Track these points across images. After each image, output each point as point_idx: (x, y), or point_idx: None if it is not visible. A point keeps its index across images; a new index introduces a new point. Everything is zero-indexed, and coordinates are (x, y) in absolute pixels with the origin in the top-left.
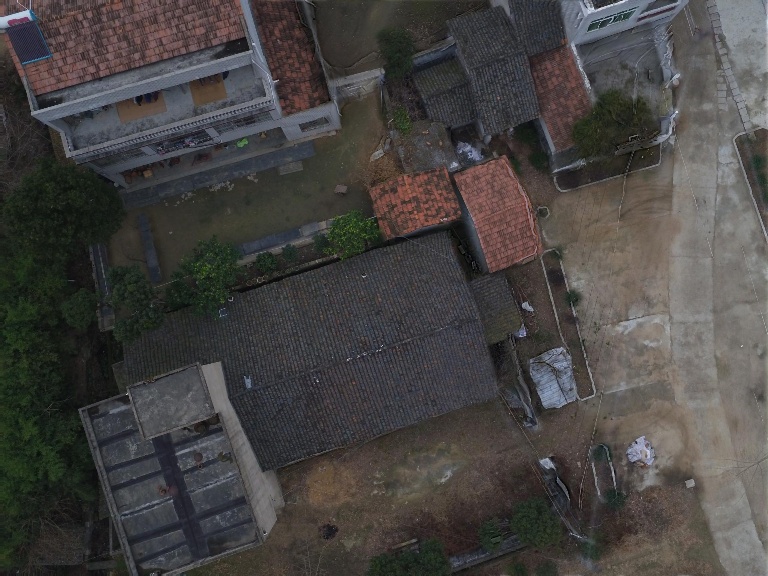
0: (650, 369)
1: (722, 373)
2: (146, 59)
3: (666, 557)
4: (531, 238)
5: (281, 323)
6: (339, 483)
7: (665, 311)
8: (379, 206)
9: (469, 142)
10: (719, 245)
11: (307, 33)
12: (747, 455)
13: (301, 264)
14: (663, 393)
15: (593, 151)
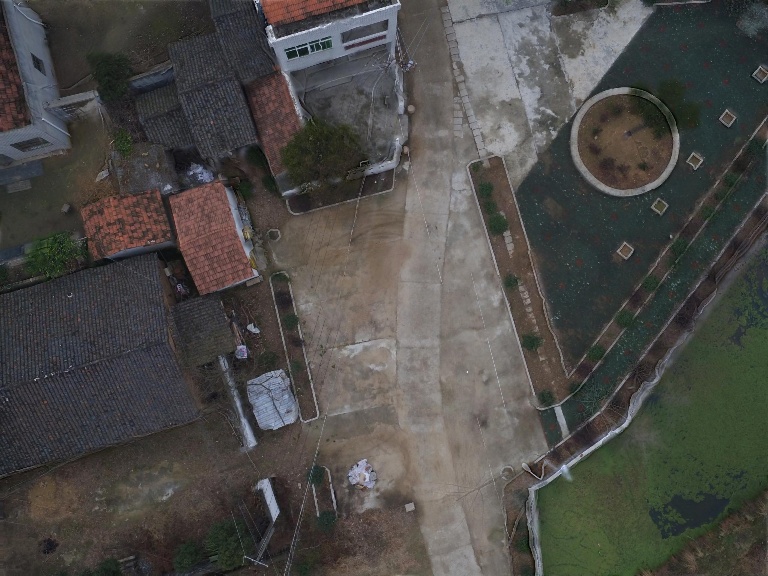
0: (375, 393)
1: (446, 398)
2: None
3: None
4: (240, 262)
5: None
6: (61, 498)
7: (392, 336)
8: (89, 227)
9: (200, 164)
10: (449, 271)
11: (10, 55)
12: (468, 480)
13: (14, 282)
14: (387, 417)
15: (319, 176)
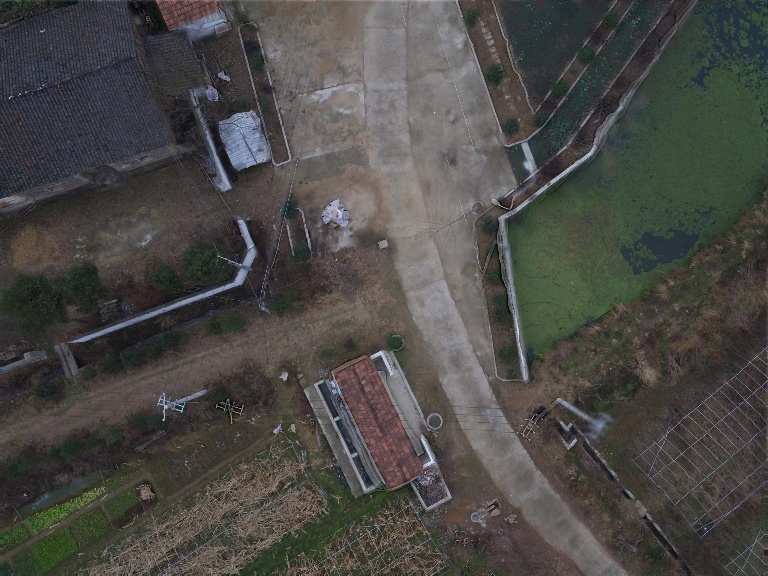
0: (345, 135)
1: (415, 138)
2: None
3: (360, 315)
4: None
5: None
6: (42, 247)
7: (360, 80)
8: None
9: None
10: (413, 16)
11: None
12: (439, 217)
13: None
14: (357, 158)
15: None
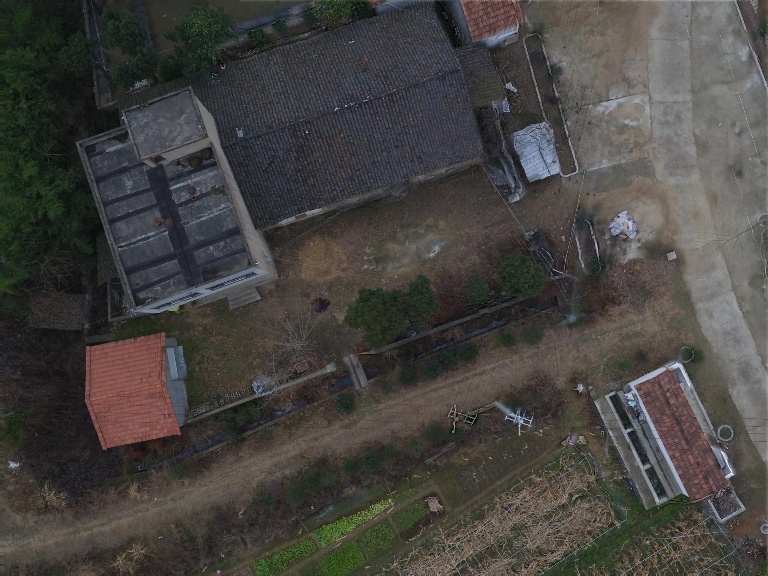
0: (631, 147)
1: (701, 150)
2: None
3: (649, 327)
4: (512, 7)
5: (271, 84)
6: (330, 258)
7: (645, 91)
8: None
9: None
10: (696, 28)
11: None
12: (727, 228)
13: (291, 36)
14: (644, 170)
15: None
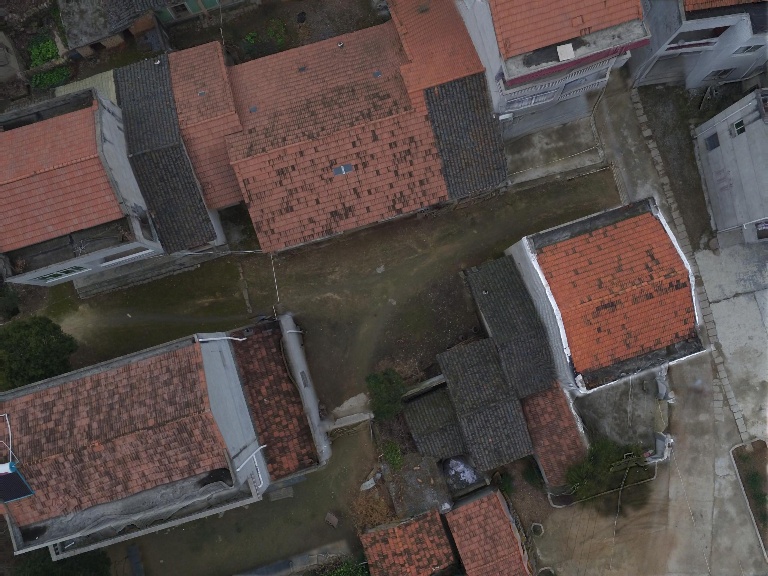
0: None
1: None
2: (128, 491)
3: None
4: None
5: None
6: None
7: None
8: (370, 553)
9: (461, 462)
10: (716, 560)
11: (294, 393)
12: None
13: None
14: None
15: (587, 474)
